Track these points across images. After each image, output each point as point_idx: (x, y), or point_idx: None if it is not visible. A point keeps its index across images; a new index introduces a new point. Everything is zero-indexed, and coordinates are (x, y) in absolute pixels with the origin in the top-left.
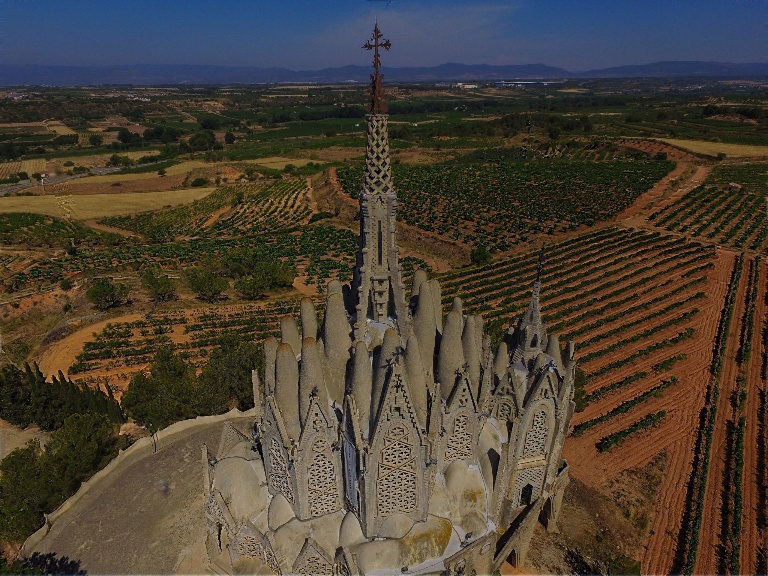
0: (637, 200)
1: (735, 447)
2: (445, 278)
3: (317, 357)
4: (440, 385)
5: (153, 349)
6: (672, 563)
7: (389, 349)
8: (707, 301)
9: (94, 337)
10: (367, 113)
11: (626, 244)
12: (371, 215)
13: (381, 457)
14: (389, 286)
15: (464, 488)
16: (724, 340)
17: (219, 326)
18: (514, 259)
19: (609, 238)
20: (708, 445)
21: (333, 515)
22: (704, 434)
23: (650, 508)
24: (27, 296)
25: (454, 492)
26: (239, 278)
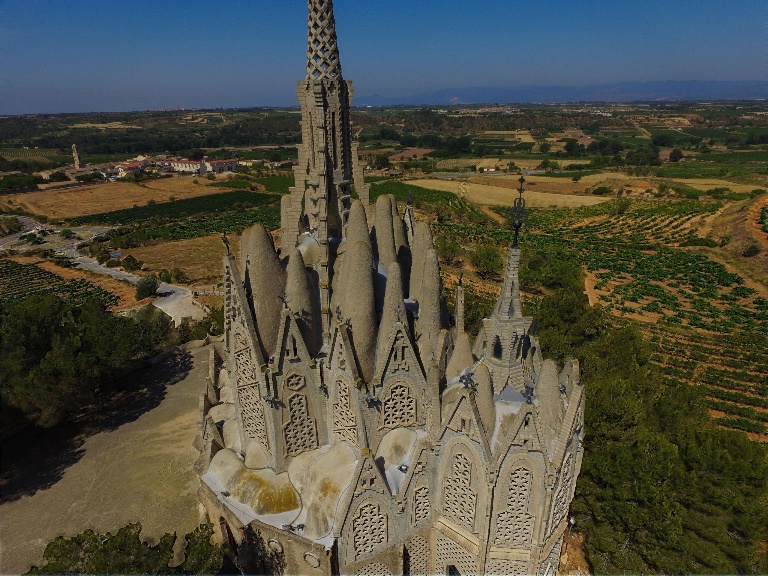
0: None
1: None
2: None
3: None
4: None
5: None
6: None
7: None
8: None
9: None
10: None
11: None
12: (305, 105)
13: None
14: None
15: (328, 474)
16: None
17: None
18: None
19: None
20: None
21: None
22: None
23: None
24: None
25: (316, 469)
26: None
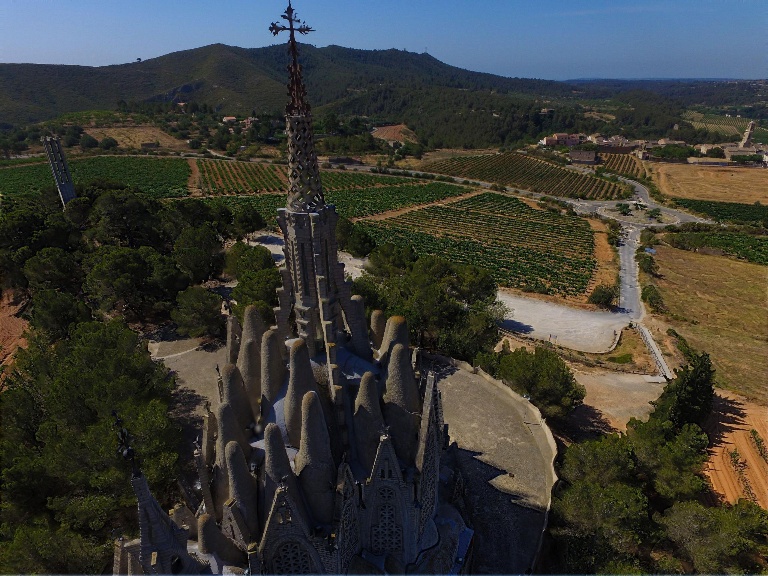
0: None
1: None
2: None
3: None
4: None
5: None
6: None
7: None
8: None
9: None
10: None
11: None
12: None
13: None
14: None
15: None
16: None
17: None
18: None
19: None
20: None
21: None
22: None
23: None
24: None
25: None
26: None
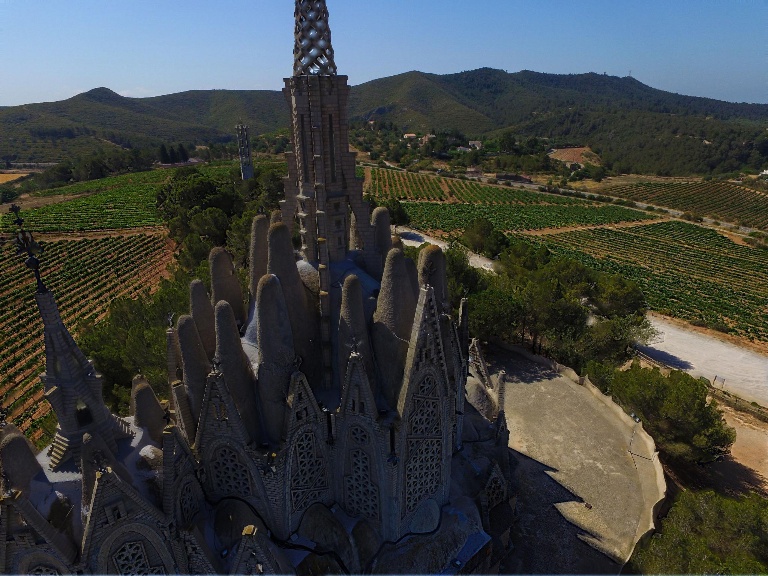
0: None
1: None
2: None
3: None
4: None
5: None
6: None
7: None
8: None
9: None
10: None
11: None
12: None
13: None
14: None
15: None
16: None
17: None
18: None
19: None
20: None
21: None
22: None
23: None
24: None
25: None
26: None
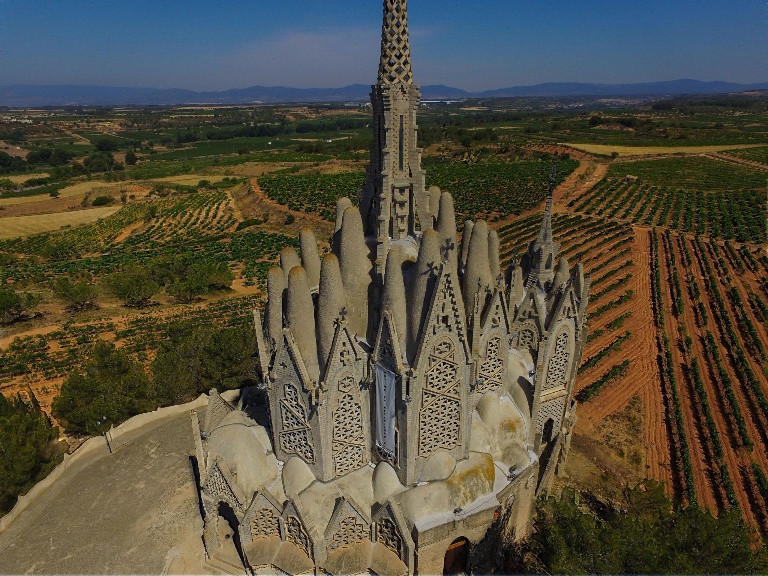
0: (554, 192)
1: (695, 383)
2: None
3: (340, 276)
4: (468, 307)
5: (79, 359)
6: (673, 491)
7: (430, 251)
8: (636, 268)
9: None
10: None
11: (555, 227)
12: (392, 108)
13: (425, 382)
14: (409, 197)
15: (501, 419)
16: (659, 298)
17: (156, 330)
18: None
19: (538, 223)
20: (673, 384)
21: (360, 471)
22: (667, 376)
23: (639, 446)
24: None
25: (492, 424)
26: (169, 283)
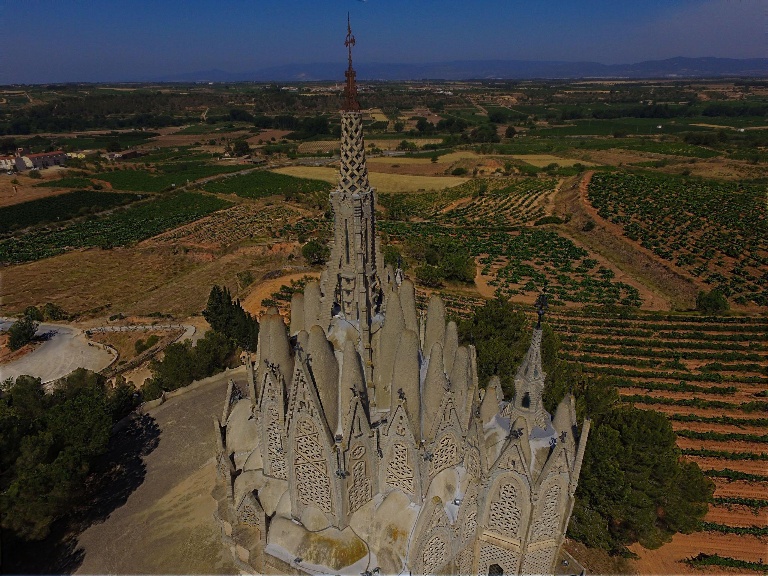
0: None
1: None
2: (644, 317)
3: (280, 334)
4: None
5: None
6: None
7: (309, 344)
8: None
9: (291, 283)
10: (345, 110)
11: None
12: (339, 212)
13: (296, 444)
14: None
15: (392, 521)
16: None
17: None
18: (765, 318)
19: None
20: None
21: None
22: None
23: None
24: (279, 242)
25: (379, 519)
26: (428, 264)
